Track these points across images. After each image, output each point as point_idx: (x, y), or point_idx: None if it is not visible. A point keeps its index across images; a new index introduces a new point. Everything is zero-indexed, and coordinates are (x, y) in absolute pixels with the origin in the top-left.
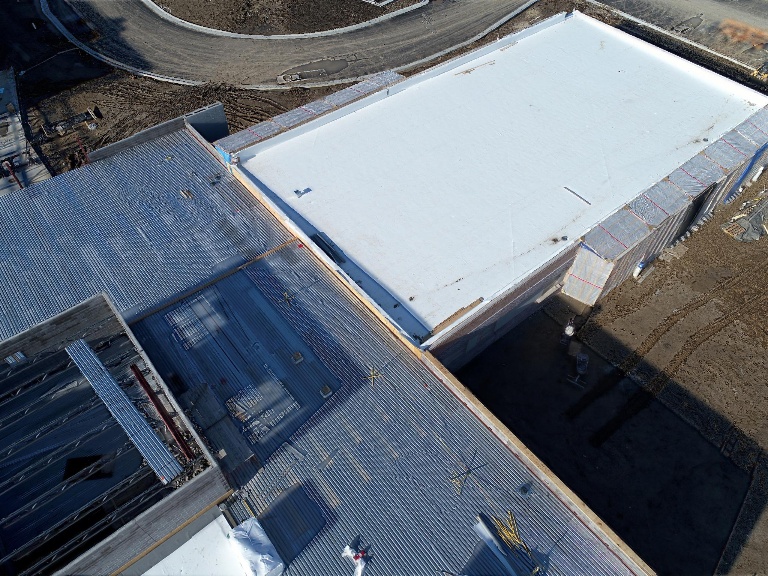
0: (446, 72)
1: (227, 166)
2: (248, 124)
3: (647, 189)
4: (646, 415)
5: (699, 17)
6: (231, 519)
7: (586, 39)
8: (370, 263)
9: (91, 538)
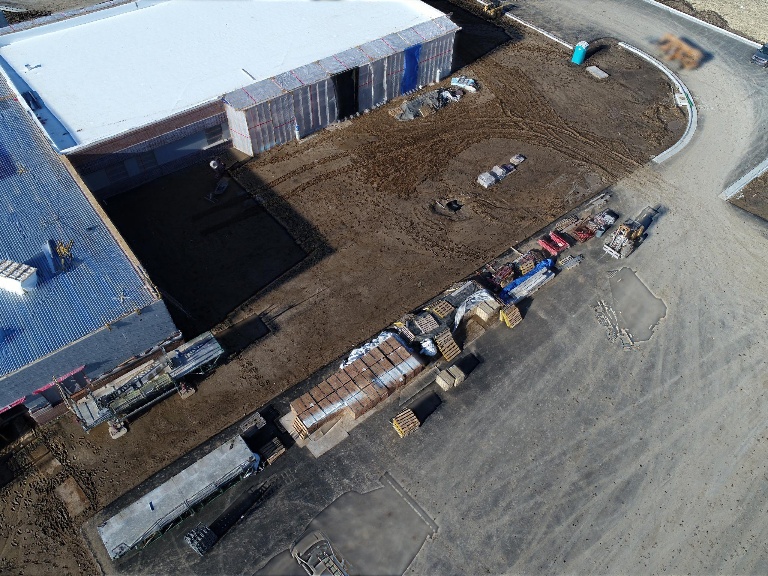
0: None
1: None
2: None
3: (296, 68)
4: (253, 220)
5: None
6: None
7: None
8: (60, 110)
9: None
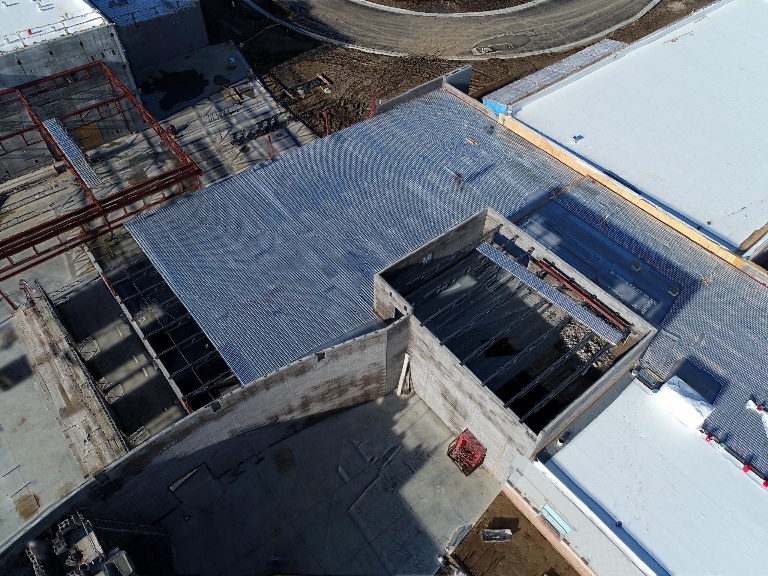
0: (655, 41)
1: (499, 118)
2: None
3: None
4: None
5: None
6: (644, 382)
7: (766, 13)
8: (661, 195)
9: (532, 396)
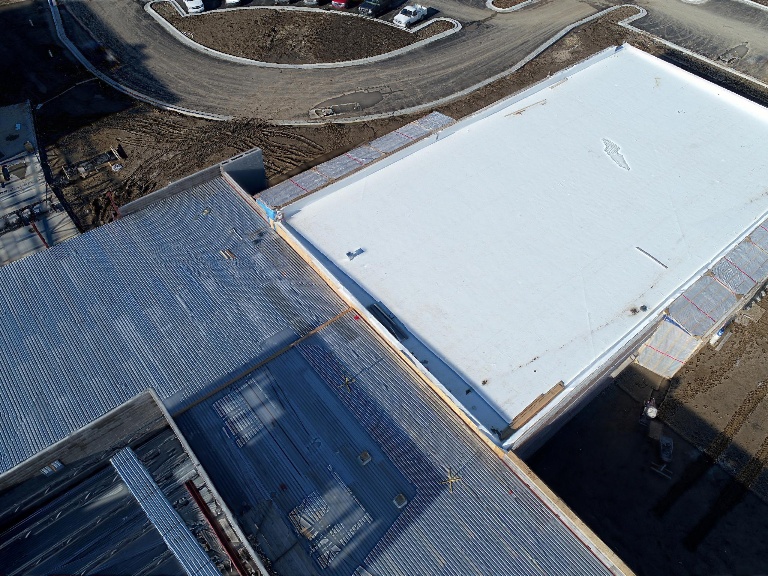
0: (496, 113)
1: (270, 222)
2: (282, 165)
3: (729, 252)
4: (742, 511)
5: (744, 46)
6: None
7: (639, 75)
8: (435, 339)
9: None
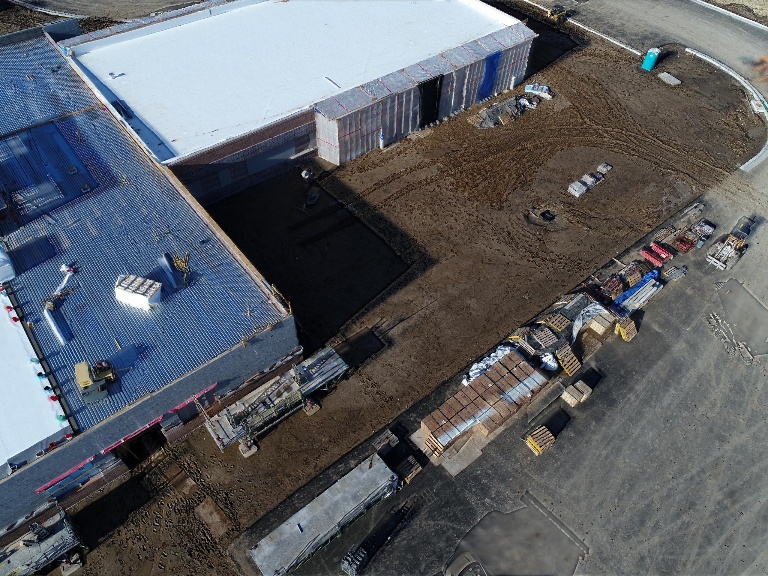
0: (267, 1)
1: (66, 59)
2: None
3: (383, 76)
4: (349, 230)
5: None
6: None
7: None
8: (151, 119)
9: None
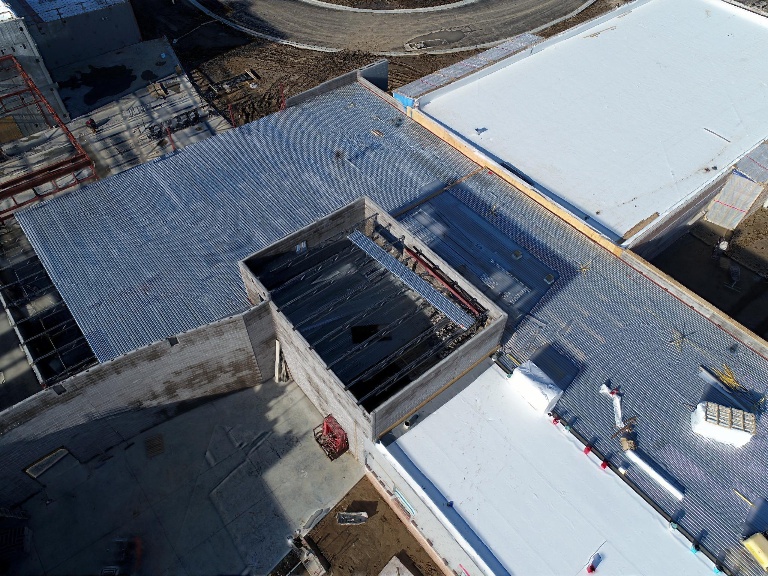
0: (575, 35)
1: (407, 111)
2: (391, 84)
3: None
4: None
5: None
6: (503, 367)
7: (692, 9)
8: (555, 186)
9: None
